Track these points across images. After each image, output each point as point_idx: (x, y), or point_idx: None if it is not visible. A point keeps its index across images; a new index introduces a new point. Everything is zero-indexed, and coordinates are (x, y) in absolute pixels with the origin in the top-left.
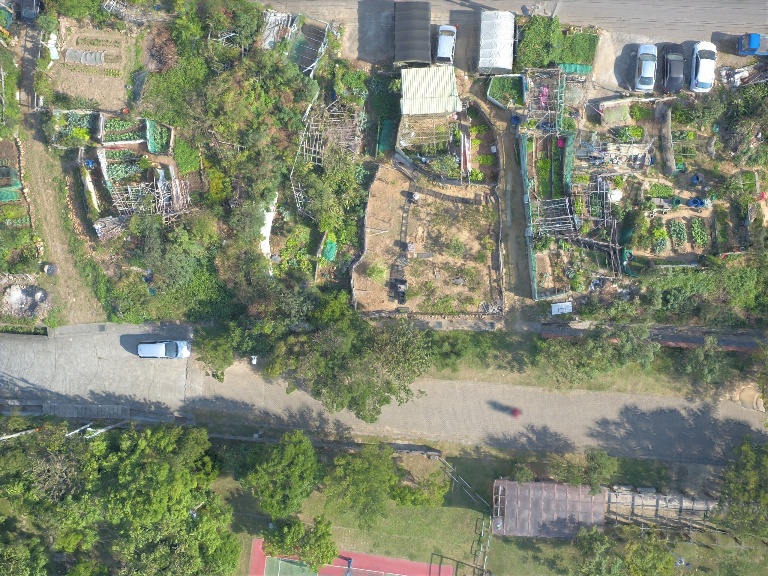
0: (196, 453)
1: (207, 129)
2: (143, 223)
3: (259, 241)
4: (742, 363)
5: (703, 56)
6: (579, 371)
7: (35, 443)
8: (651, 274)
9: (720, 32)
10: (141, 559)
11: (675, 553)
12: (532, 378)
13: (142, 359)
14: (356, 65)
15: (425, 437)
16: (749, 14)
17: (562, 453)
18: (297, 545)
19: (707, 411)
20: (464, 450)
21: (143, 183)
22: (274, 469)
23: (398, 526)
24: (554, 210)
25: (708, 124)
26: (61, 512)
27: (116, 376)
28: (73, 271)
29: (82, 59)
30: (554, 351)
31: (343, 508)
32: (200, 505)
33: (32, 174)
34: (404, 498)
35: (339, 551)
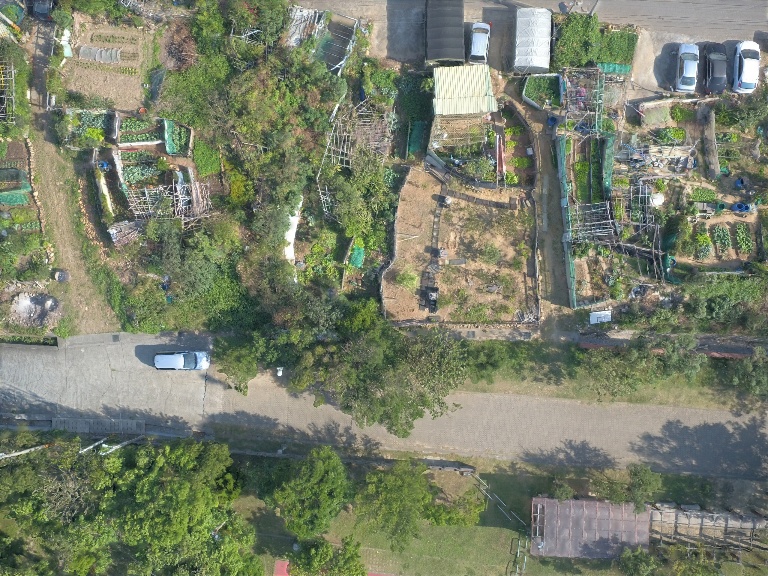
0: (217, 470)
1: (229, 130)
2: (161, 228)
3: (283, 247)
4: None
5: (746, 56)
6: (622, 383)
7: (44, 460)
8: (696, 281)
9: (763, 31)
10: None
11: None
12: (570, 390)
13: (158, 371)
14: (385, 63)
15: (457, 452)
16: None
17: (601, 469)
18: (325, 568)
19: (753, 424)
20: (499, 466)
21: (161, 186)
22: (302, 487)
23: (429, 546)
24: (594, 214)
25: (752, 126)
26: (73, 534)
27: (130, 389)
28: (85, 278)
29: (97, 56)
30: (596, 362)
31: (373, 528)
32: (221, 526)
33: (43, 176)
34: (439, 517)
35: (367, 573)
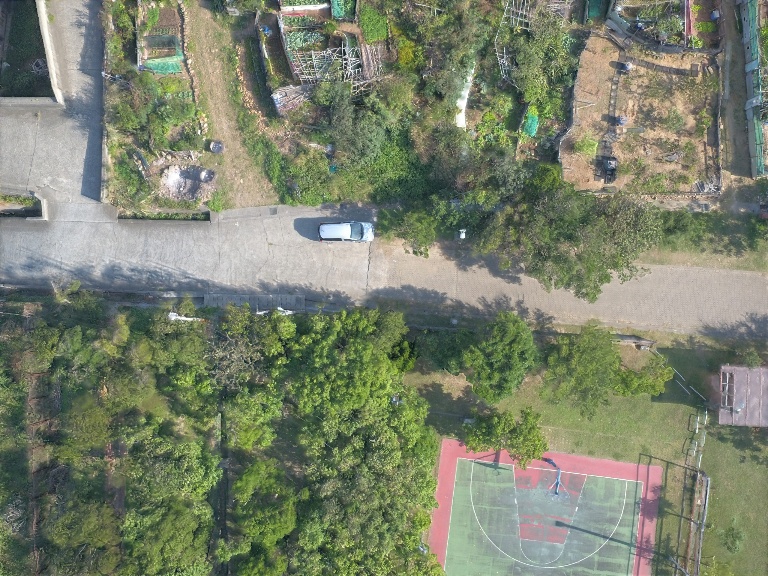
0: (395, 337)
1: None
2: (333, 89)
3: (455, 113)
4: None
5: None
6: None
7: None
8: None
9: None
10: (333, 454)
11: None
12: (750, 262)
13: (319, 244)
14: None
15: (634, 327)
16: None
17: None
18: (509, 436)
19: None
20: (677, 340)
21: (329, 49)
22: (493, 349)
23: (603, 424)
24: None
25: None
26: (242, 403)
27: (289, 263)
28: (241, 150)
29: None
30: None
31: (555, 398)
32: (397, 395)
33: (196, 44)
34: (631, 382)
35: None
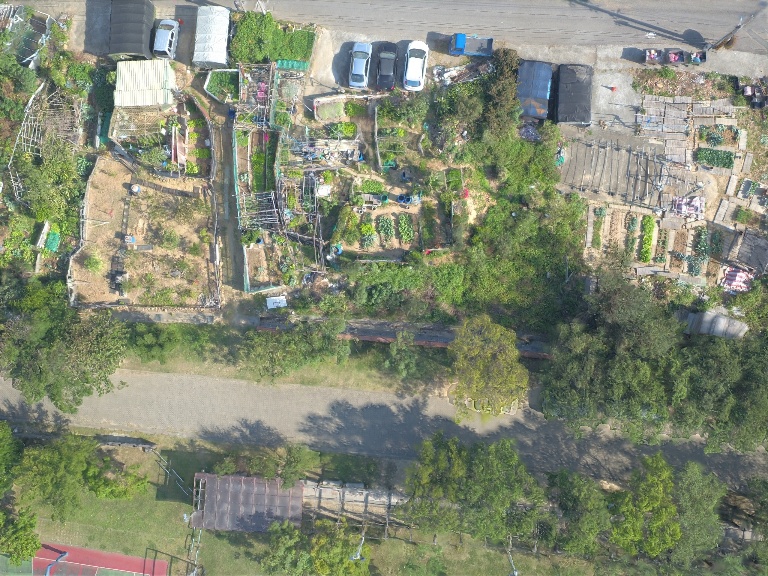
0: None
1: None
2: None
3: None
4: (451, 360)
5: (413, 55)
6: (275, 364)
7: None
8: (349, 268)
9: (435, 32)
10: None
11: (383, 550)
12: (247, 372)
13: None
14: (79, 57)
15: (141, 430)
16: (463, 15)
17: (275, 448)
18: None
19: (416, 407)
20: (179, 443)
21: None
22: None
23: (113, 520)
24: (260, 203)
25: (419, 122)
26: None
27: None
28: None
29: None
30: (252, 344)
31: (47, 500)
32: None
33: None
34: (97, 489)
35: (55, 544)
